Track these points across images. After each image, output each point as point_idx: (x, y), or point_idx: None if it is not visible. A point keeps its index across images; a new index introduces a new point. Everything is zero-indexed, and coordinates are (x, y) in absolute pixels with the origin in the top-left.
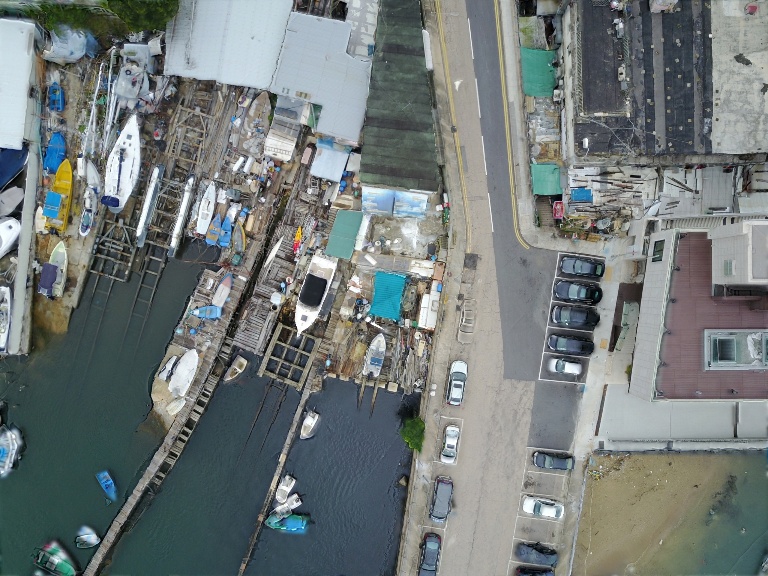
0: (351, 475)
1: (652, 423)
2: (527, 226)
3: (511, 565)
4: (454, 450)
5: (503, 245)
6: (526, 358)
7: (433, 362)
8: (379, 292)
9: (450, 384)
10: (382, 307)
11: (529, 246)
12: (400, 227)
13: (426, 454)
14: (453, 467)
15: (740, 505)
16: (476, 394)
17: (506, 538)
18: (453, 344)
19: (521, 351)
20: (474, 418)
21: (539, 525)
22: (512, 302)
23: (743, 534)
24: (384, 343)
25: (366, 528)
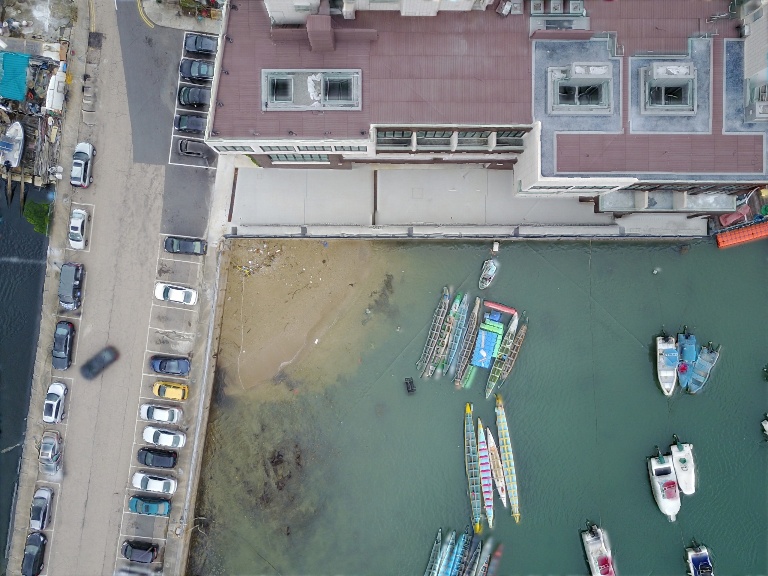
0: (11, 279)
1: (286, 209)
2: (150, 3)
3: (147, 355)
4: (79, 233)
5: (127, 23)
6: (155, 141)
7: (60, 145)
8: (7, 75)
9: (72, 164)
10: (7, 88)
11: (154, 24)
12: (31, 10)
13: (57, 241)
14: (86, 254)
15: (397, 305)
16: (106, 179)
17: (141, 327)
18: (81, 127)
19: (150, 134)
20: (105, 204)
21: (175, 314)
22: (139, 83)
23: (398, 333)
24: (21, 132)
25: (23, 330)
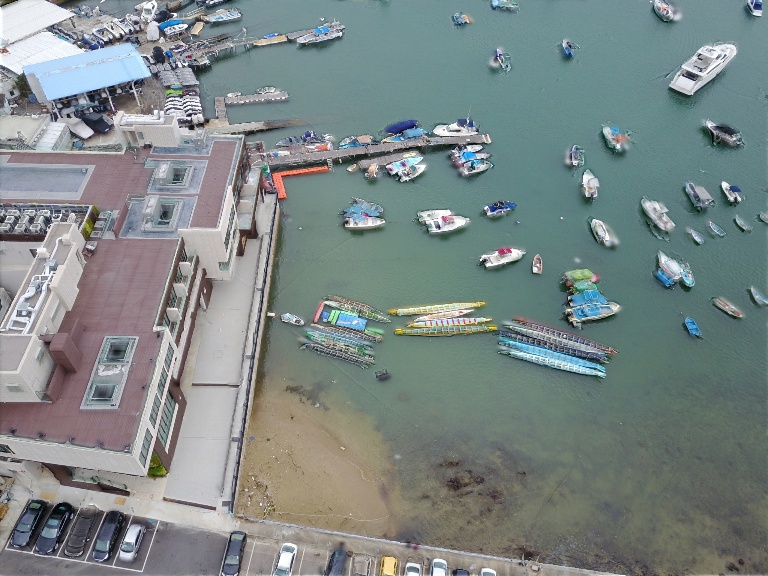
0: None
1: (213, 455)
2: None
3: None
4: None
5: None
6: None
7: None
8: None
9: None
10: None
11: None
12: None
13: None
14: None
15: (313, 384)
16: None
17: None
18: None
19: None
20: None
21: (306, 571)
22: None
23: (337, 382)
24: None
25: None
